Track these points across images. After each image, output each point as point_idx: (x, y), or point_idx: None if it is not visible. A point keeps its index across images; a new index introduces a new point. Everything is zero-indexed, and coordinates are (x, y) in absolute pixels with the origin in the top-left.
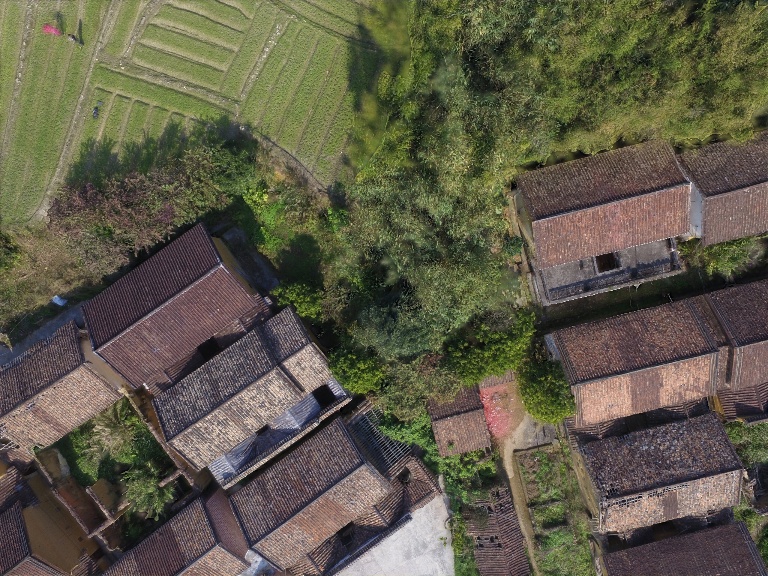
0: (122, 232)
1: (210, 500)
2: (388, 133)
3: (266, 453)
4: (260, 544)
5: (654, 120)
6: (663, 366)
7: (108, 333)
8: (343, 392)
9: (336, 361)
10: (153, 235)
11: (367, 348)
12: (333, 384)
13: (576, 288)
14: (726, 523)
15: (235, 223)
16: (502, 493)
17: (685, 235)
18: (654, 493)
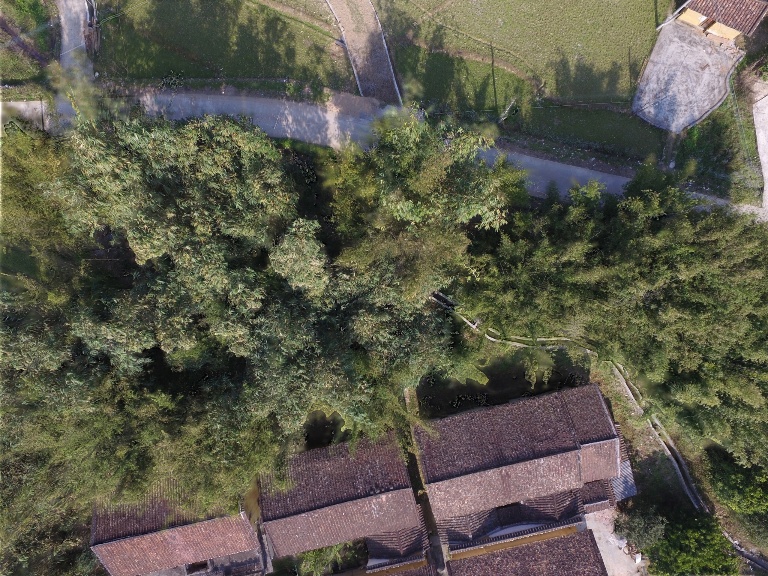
0: None
1: None
2: None
3: None
4: None
5: None
6: None
7: None
8: None
9: None
10: None
11: None
12: None
13: None
14: None
15: None
16: None
17: None
18: None
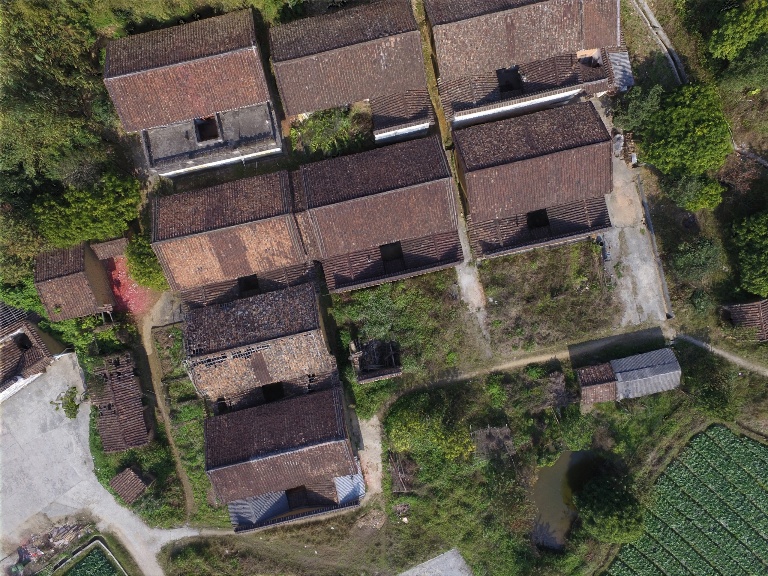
0: None
1: None
2: None
3: None
4: None
5: None
6: (239, 227)
7: None
8: None
9: None
10: None
11: None
12: None
13: (181, 158)
14: (324, 390)
15: None
16: (122, 362)
17: None
18: (239, 353)
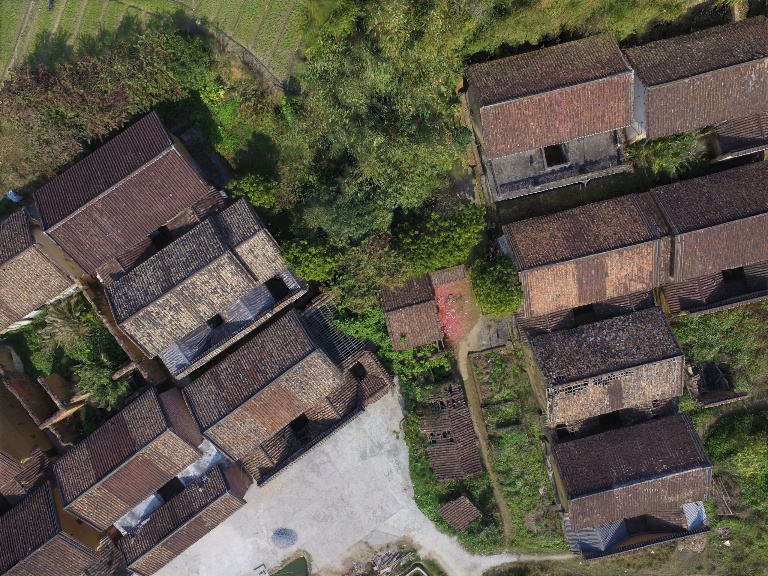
0: (74, 116)
1: (164, 393)
2: (336, 7)
3: (219, 343)
4: (212, 431)
5: (595, 3)
6: (607, 253)
7: (59, 215)
8: (297, 285)
9: (288, 248)
10: (107, 122)
11: (319, 237)
12: (287, 277)
13: (526, 184)
14: (670, 415)
15: (193, 124)
16: (455, 390)
17: (633, 136)
18: (599, 380)
